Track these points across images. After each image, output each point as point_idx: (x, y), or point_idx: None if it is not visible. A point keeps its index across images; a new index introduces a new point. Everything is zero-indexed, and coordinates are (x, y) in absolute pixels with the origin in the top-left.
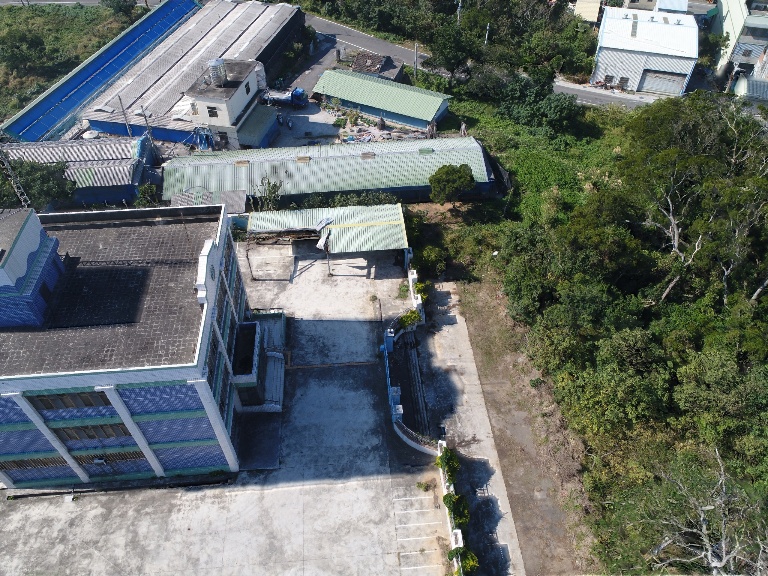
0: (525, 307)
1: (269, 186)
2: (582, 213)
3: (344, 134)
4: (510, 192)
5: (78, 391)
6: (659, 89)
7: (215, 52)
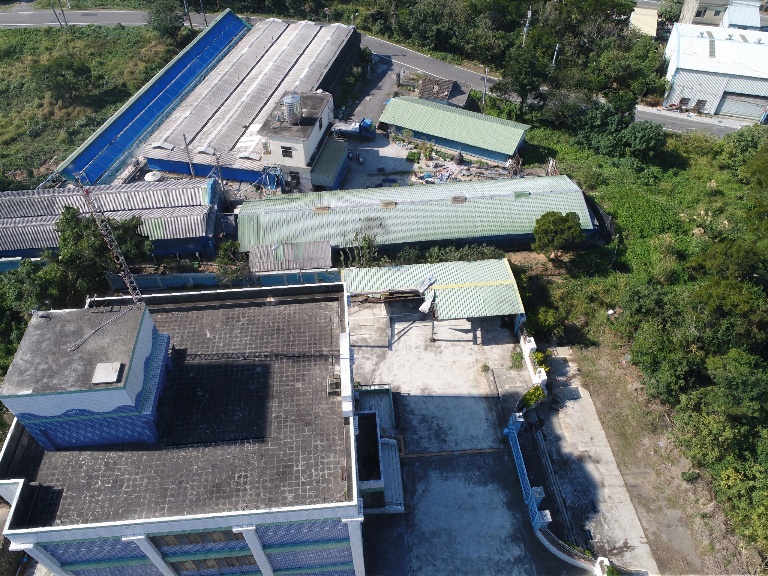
0: (666, 384)
1: (365, 242)
2: (701, 265)
3: (419, 170)
4: (616, 239)
5: (210, 530)
6: (739, 112)
7: (273, 79)
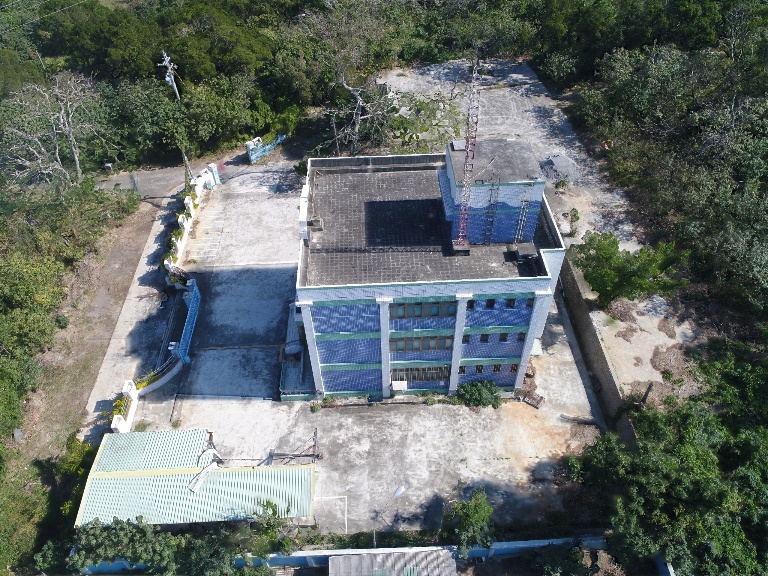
0: None
1: (270, 504)
2: None
3: None
4: None
5: None
6: None
7: None
